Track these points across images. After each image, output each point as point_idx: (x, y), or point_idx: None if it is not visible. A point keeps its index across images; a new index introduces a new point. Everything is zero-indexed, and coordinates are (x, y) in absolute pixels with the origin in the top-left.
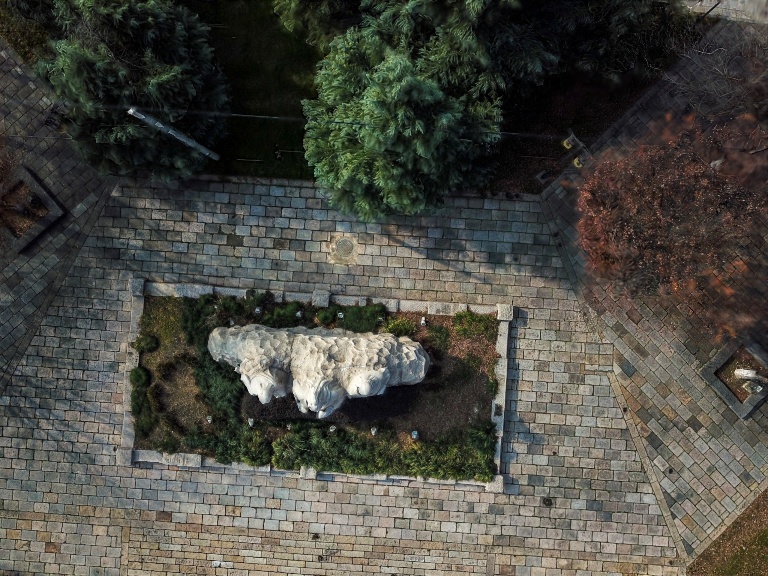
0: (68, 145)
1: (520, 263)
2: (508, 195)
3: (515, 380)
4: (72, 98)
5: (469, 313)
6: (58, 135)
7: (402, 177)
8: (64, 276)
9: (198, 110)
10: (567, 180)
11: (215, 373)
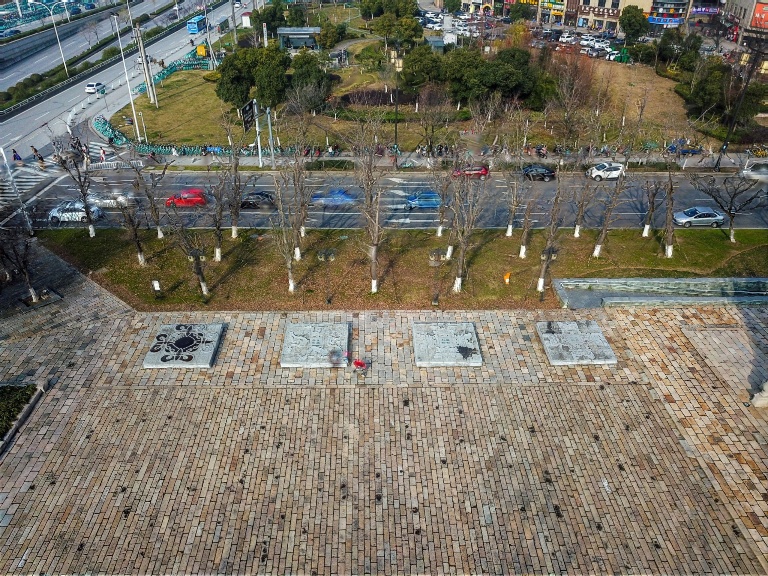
0: None
1: None
2: None
3: None
4: None
5: None
6: None
7: None
8: None
9: None
10: None
11: None
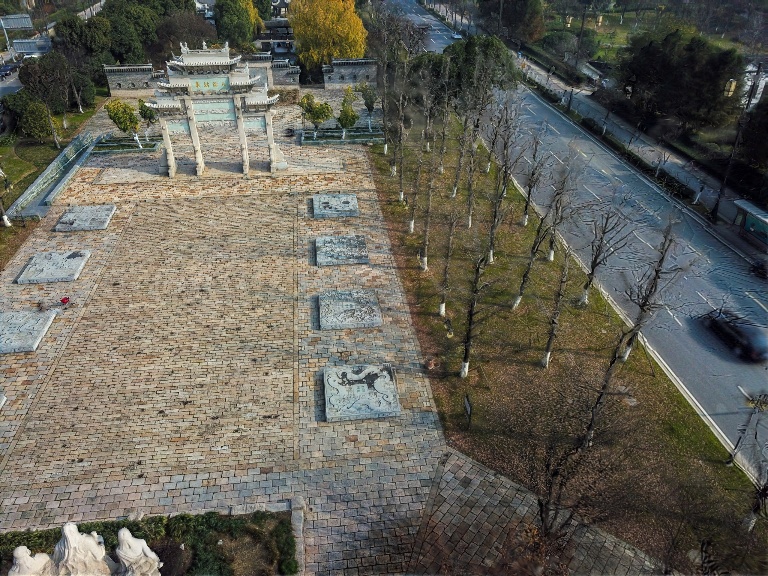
0: None
1: None
2: None
3: None
4: None
5: None
6: None
7: None
8: None
9: None
10: None
11: None
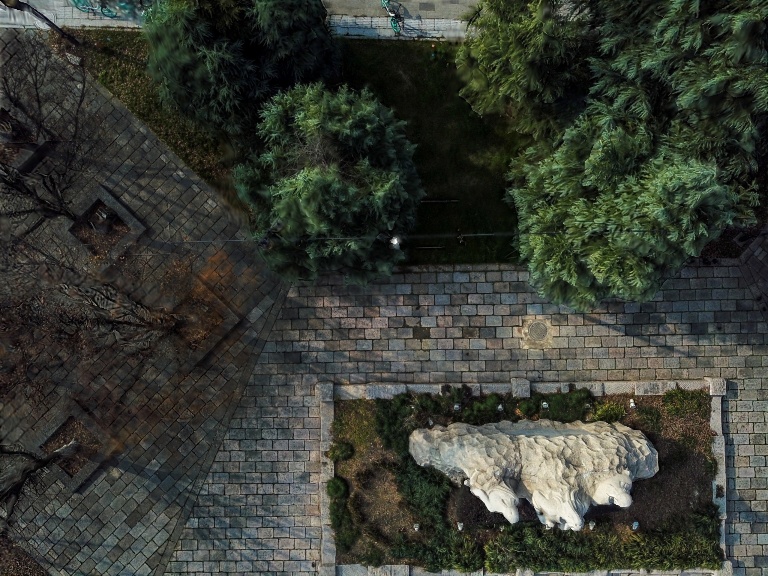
0: (238, 247)
1: (724, 332)
2: (705, 261)
3: (731, 456)
4: (296, 219)
5: (679, 391)
6: (227, 238)
7: None
8: (244, 386)
9: None
10: (765, 240)
11: (420, 478)
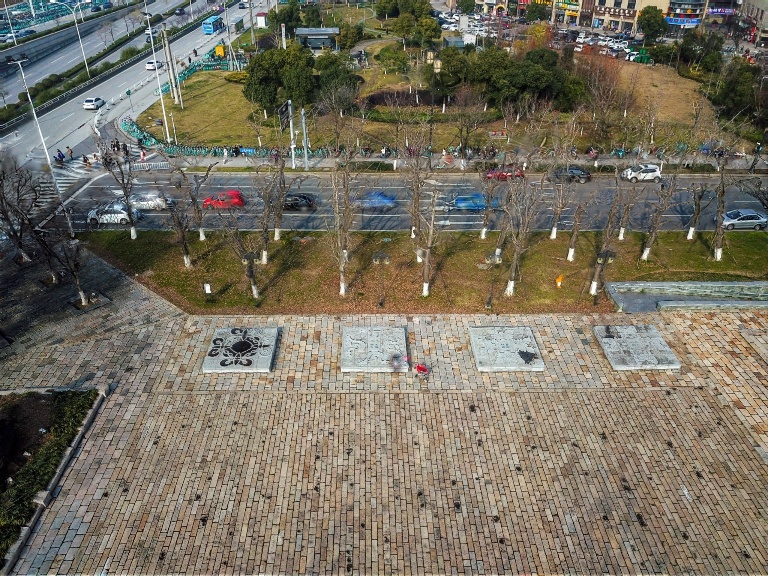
0: None
1: None
2: None
3: None
4: None
5: None
6: None
7: None
8: None
9: None
10: None
11: None
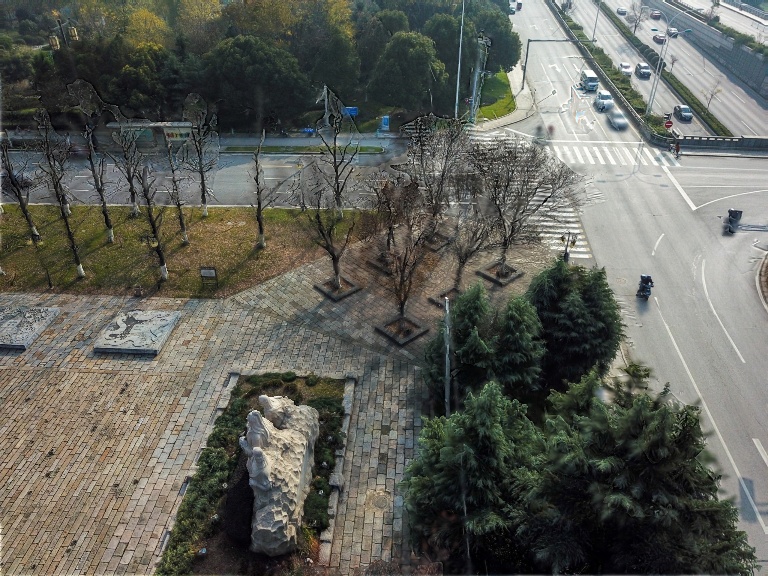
0: None
1: None
2: None
3: None
4: None
5: None
6: None
7: (428, 464)
8: (361, 346)
9: (474, 384)
10: None
11: None
